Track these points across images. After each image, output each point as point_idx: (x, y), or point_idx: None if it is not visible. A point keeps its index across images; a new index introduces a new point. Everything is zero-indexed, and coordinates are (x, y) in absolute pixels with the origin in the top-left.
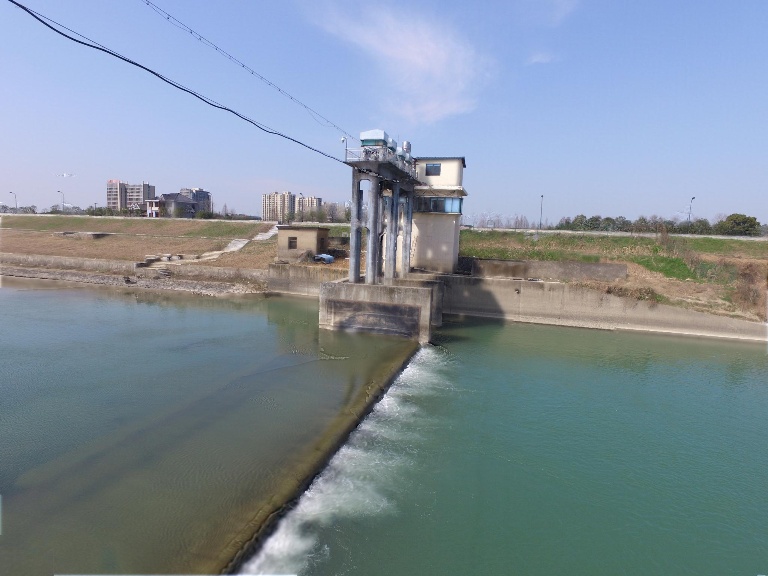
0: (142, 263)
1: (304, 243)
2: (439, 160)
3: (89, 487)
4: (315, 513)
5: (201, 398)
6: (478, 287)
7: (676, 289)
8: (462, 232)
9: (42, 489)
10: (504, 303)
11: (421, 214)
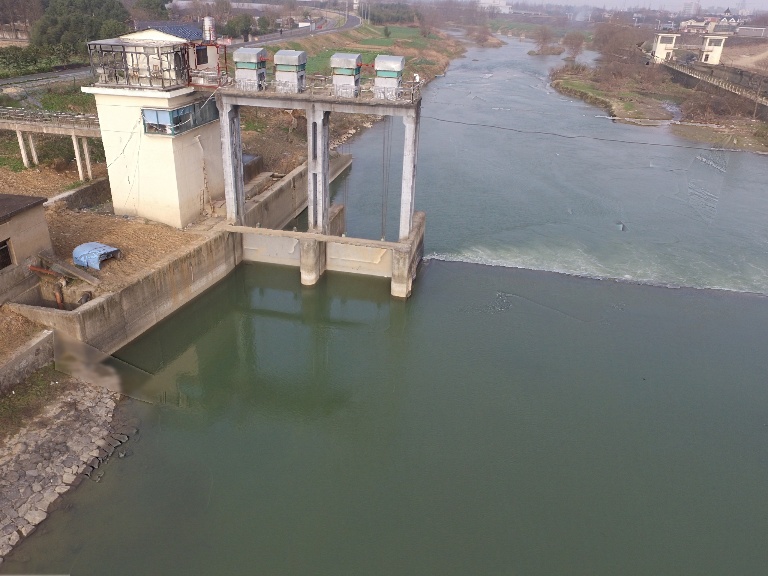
0: None
1: (28, 243)
2: None
3: (745, 331)
4: (699, 287)
5: (637, 328)
6: None
7: (281, 141)
8: None
9: (760, 340)
10: None
11: (207, 125)
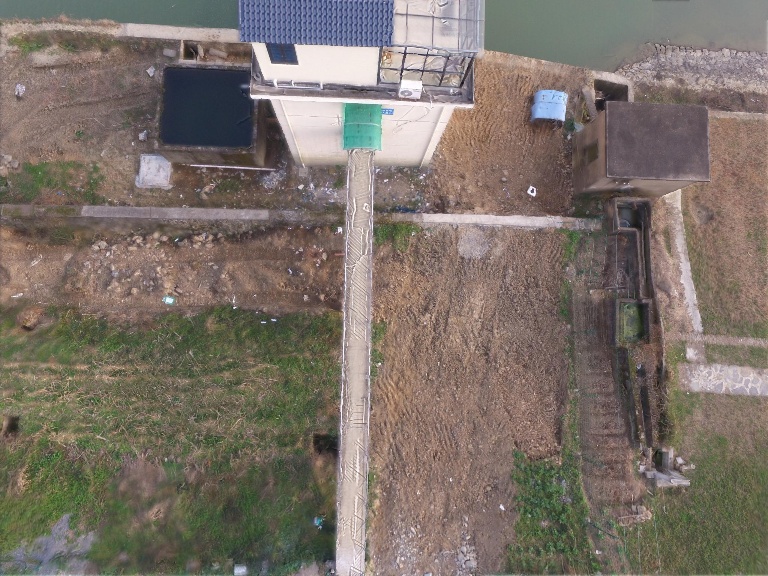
0: None
1: None
2: None
3: None
4: None
5: None
6: None
7: None
8: (301, 544)
9: None
10: None
11: None
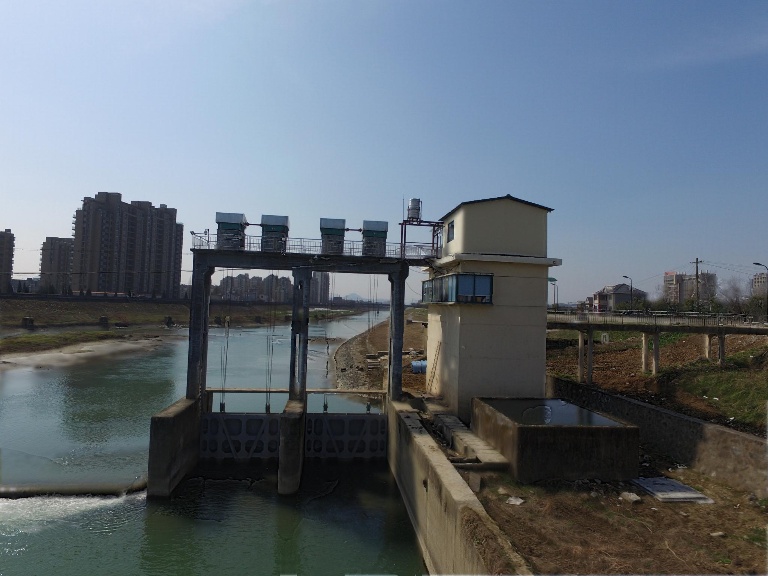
0: (373, 355)
1: None
2: (452, 214)
3: None
4: None
5: None
6: (409, 451)
7: None
8: None
9: None
10: (419, 504)
11: (439, 306)
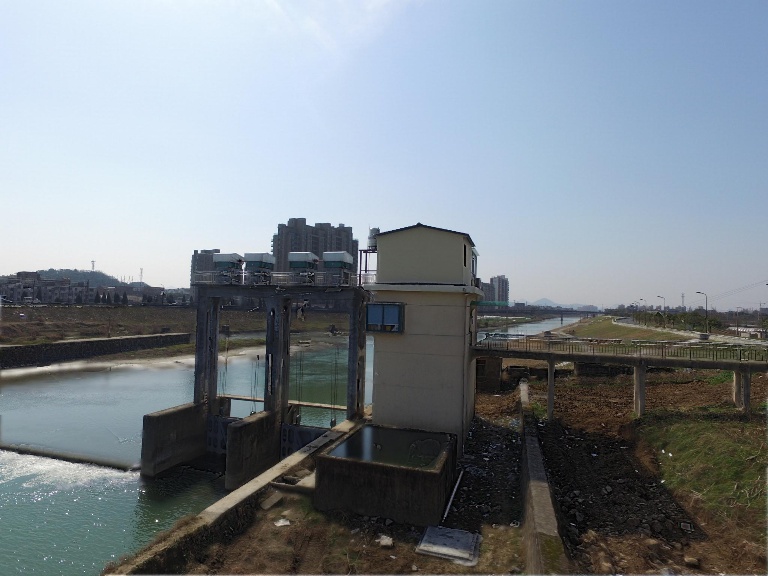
0: None
1: None
2: None
3: None
4: None
5: None
6: None
7: None
8: None
9: None
10: None
11: None
